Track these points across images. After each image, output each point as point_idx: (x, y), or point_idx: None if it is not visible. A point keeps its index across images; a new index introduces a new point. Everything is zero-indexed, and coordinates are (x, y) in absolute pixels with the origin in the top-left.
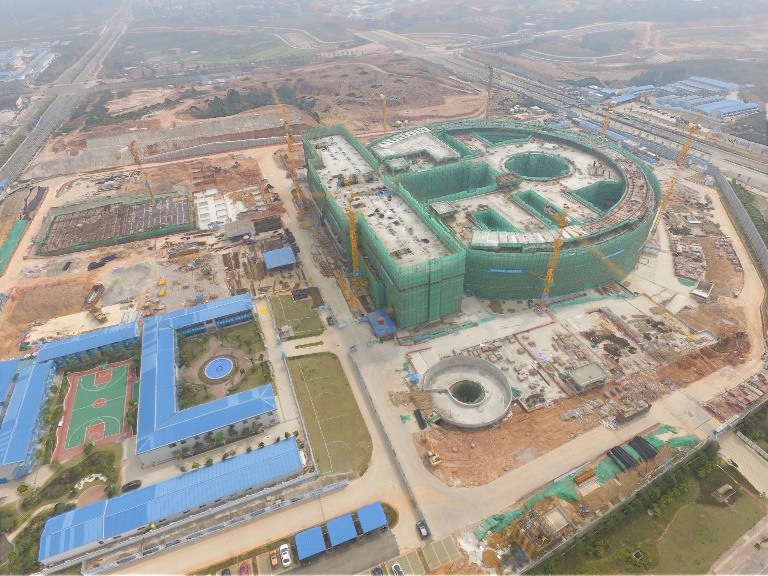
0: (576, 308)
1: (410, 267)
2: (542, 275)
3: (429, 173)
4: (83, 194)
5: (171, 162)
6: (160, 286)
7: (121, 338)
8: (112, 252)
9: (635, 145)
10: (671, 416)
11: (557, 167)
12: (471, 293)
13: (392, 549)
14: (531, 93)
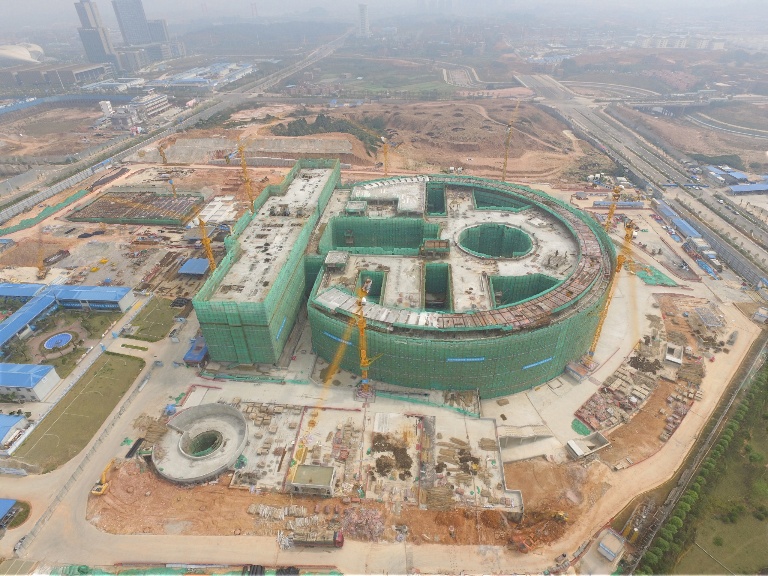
0: (401, 405)
1: (203, 302)
2: None
3: (380, 222)
4: (142, 180)
5: (225, 167)
6: (100, 264)
7: (24, 294)
8: (106, 228)
9: (702, 246)
10: (362, 567)
11: (527, 247)
12: (316, 351)
13: None
14: (640, 162)
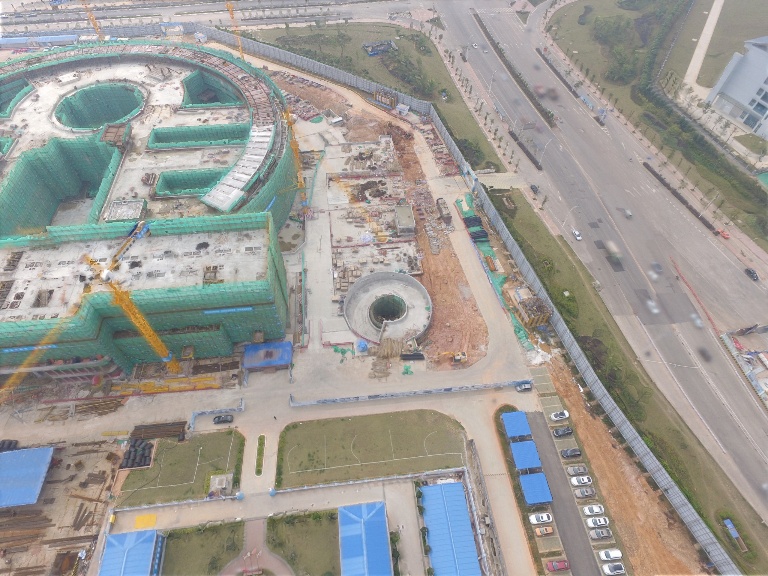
0: (318, 192)
1: (267, 270)
2: (291, 186)
3: (3, 199)
4: None
5: None
6: None
7: None
8: None
9: (96, 38)
10: (447, 195)
11: (110, 95)
12: None
13: (538, 417)
14: None
